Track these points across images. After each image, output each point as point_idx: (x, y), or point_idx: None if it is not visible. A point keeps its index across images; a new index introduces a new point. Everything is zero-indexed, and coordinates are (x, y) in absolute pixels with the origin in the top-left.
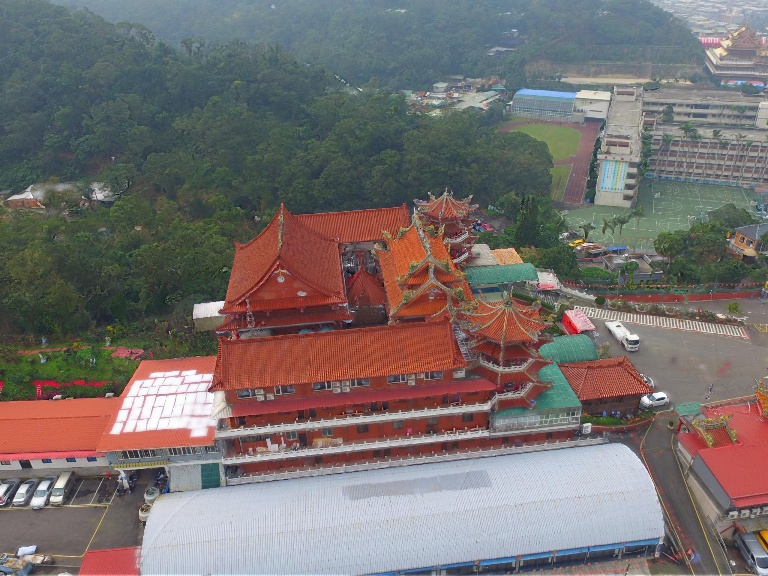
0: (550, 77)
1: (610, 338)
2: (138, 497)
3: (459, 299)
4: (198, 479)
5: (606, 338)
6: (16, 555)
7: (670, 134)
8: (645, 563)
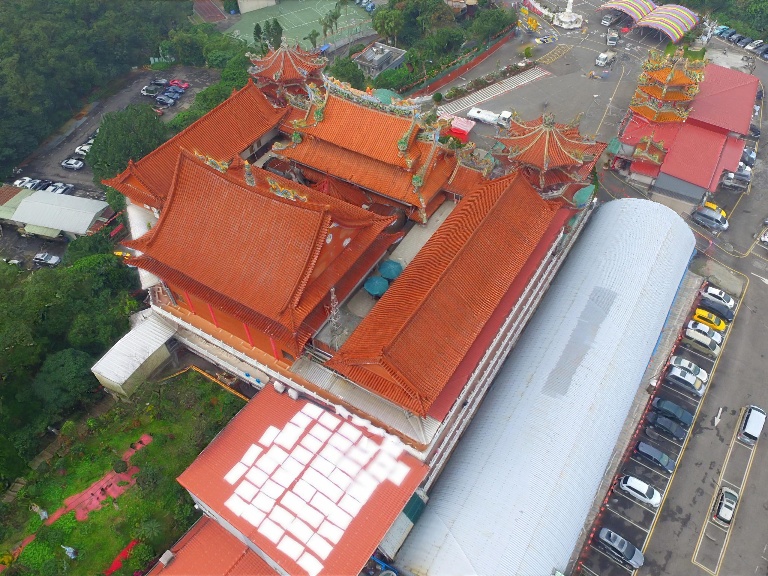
0: None
1: (483, 126)
2: None
3: (453, 151)
4: (404, 520)
5: (480, 128)
6: None
7: None
8: (688, 271)
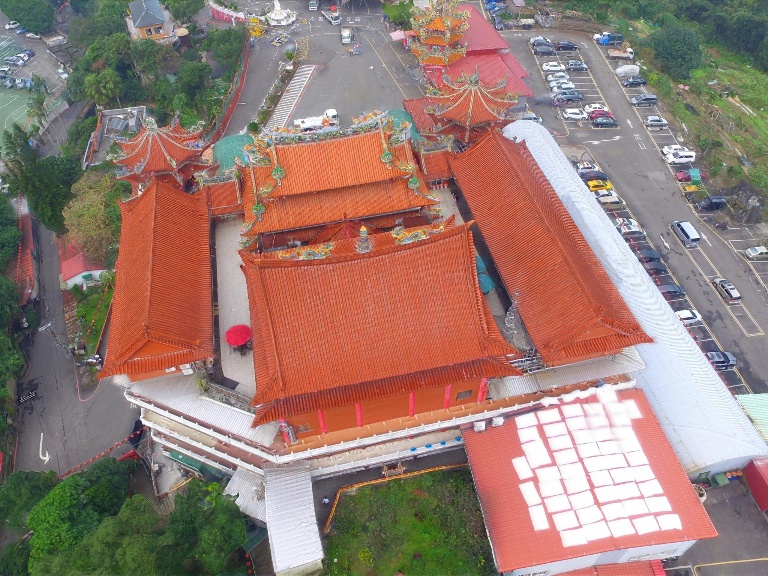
0: None
1: None
2: None
3: None
4: None
5: None
6: None
7: None
8: None
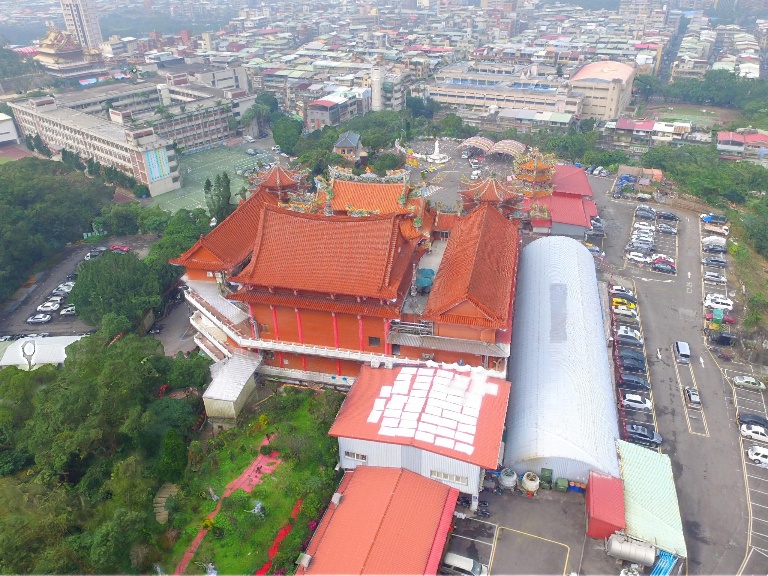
0: None
1: None
2: (495, 500)
3: None
4: None
5: None
6: None
7: (149, 120)
8: None
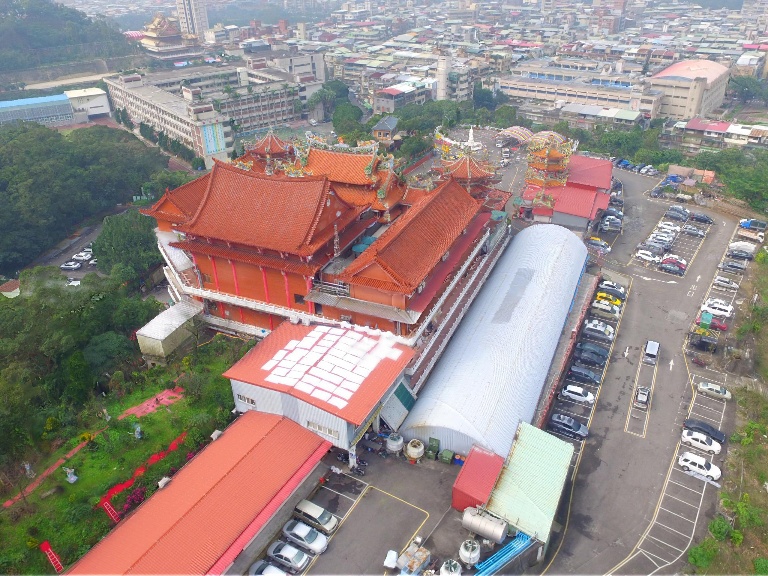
0: (10, 87)
1: None
2: (377, 461)
3: (403, 182)
4: (401, 406)
5: None
6: (393, 569)
7: (217, 99)
8: (587, 274)
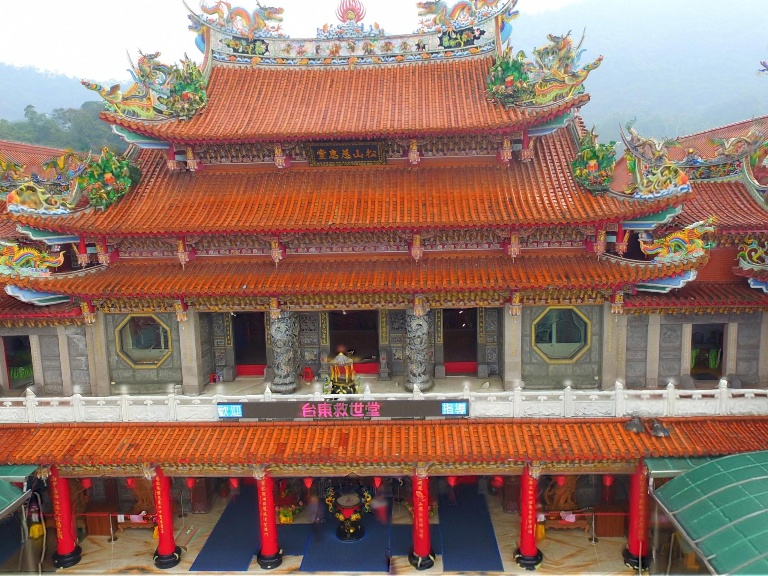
0: None
1: None
2: None
3: None
4: None
5: None
6: None
7: None
8: None
